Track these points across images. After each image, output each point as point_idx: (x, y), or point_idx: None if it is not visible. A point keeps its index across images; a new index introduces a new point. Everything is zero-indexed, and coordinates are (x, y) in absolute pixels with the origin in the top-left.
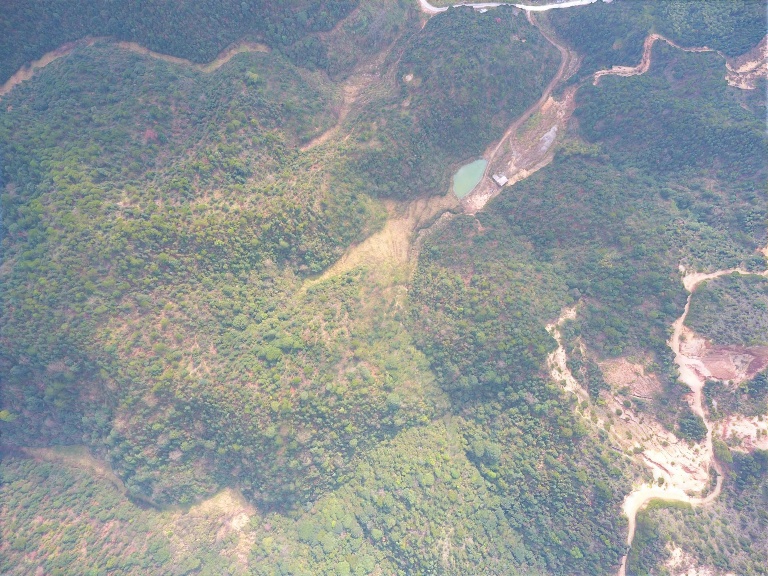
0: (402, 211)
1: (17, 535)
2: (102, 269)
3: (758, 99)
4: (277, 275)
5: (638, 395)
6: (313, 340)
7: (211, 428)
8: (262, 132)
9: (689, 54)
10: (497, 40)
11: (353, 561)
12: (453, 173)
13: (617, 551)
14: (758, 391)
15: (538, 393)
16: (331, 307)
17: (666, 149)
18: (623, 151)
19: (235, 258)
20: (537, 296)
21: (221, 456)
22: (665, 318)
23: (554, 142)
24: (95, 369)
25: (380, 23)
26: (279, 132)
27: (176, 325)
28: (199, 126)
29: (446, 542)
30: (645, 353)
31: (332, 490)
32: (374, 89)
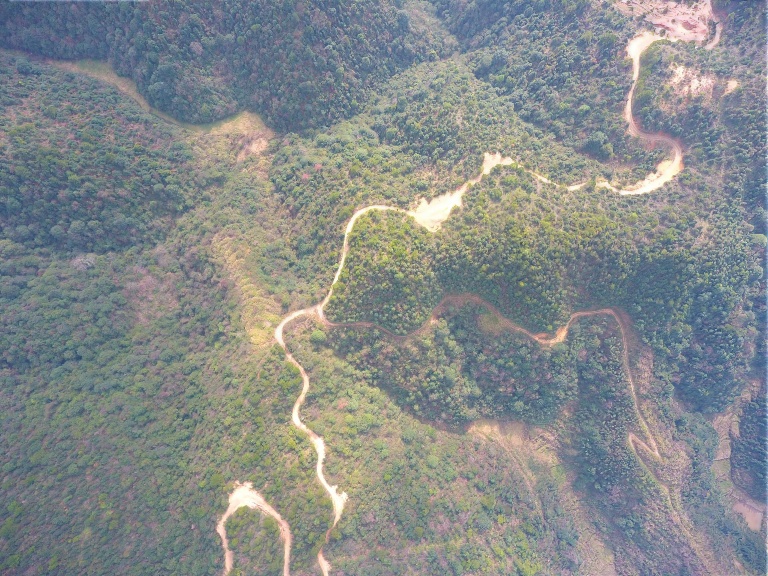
0: None
1: None
2: None
3: None
4: None
5: None
6: None
7: (230, 14)
8: None
9: None
10: None
11: (370, 147)
12: None
13: (623, 87)
14: None
15: None
16: None
17: None
18: None
19: None
20: None
21: (240, 56)
22: None
23: None
24: None
25: None
26: None
27: None
28: None
29: (459, 114)
30: None
31: (347, 119)
32: None
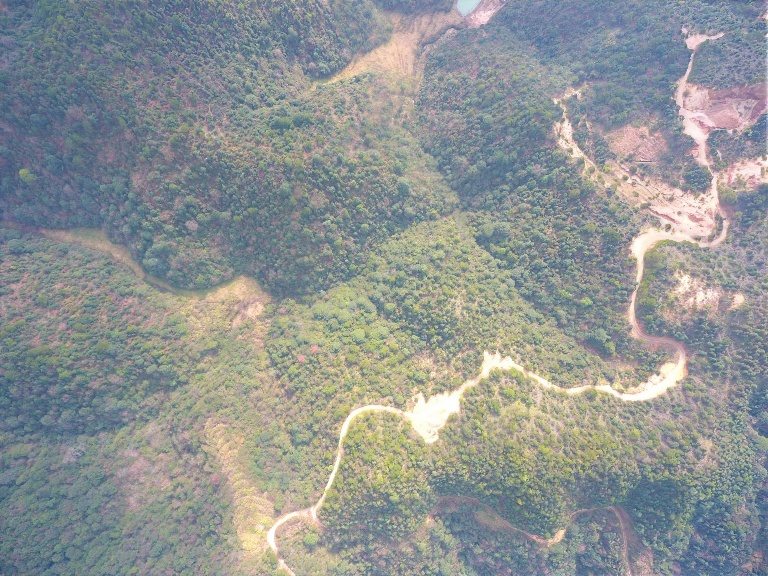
0: (407, 24)
1: (39, 295)
2: (118, 18)
3: None
4: (287, 69)
5: (644, 160)
6: None
7: (226, 195)
8: None
9: None
10: None
11: (368, 328)
12: None
13: (626, 289)
14: (761, 134)
15: (545, 164)
16: (340, 98)
17: None
18: None
19: (246, 38)
20: (542, 79)
21: (236, 231)
22: (669, 78)
23: None
24: (112, 124)
25: None
26: None
27: (190, 89)
28: None
29: (458, 300)
30: (650, 115)
31: (345, 281)
32: None
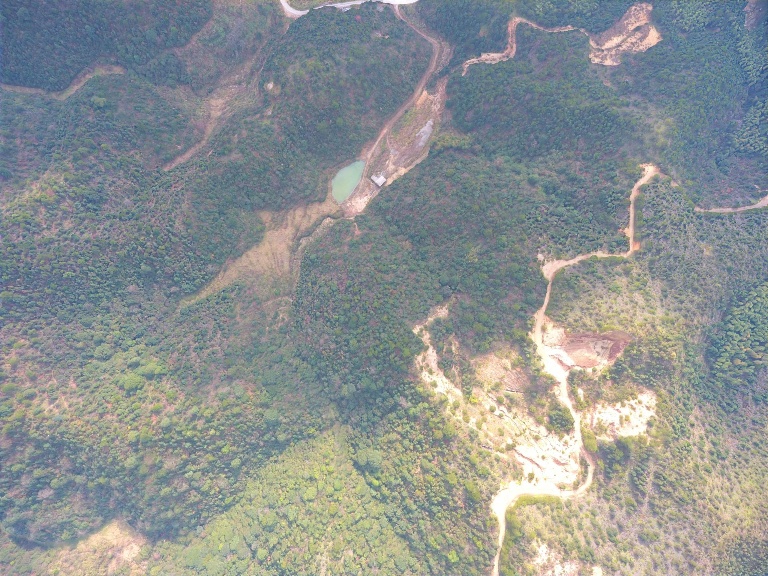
0: (279, 221)
1: None
2: None
3: (622, 75)
4: (145, 300)
5: (510, 390)
6: (177, 364)
7: (77, 463)
8: (116, 156)
9: (551, 35)
10: (356, 39)
11: None
12: (330, 178)
13: (488, 552)
14: (620, 376)
15: (411, 397)
16: (202, 327)
17: (532, 135)
18: (494, 140)
19: (91, 288)
20: (407, 297)
21: (95, 489)
22: (527, 309)
23: (431, 137)
24: None
25: (239, 33)
26: (136, 154)
27: (28, 363)
28: (46, 157)
29: (324, 557)
30: (511, 347)
31: (223, 512)
32: (239, 100)
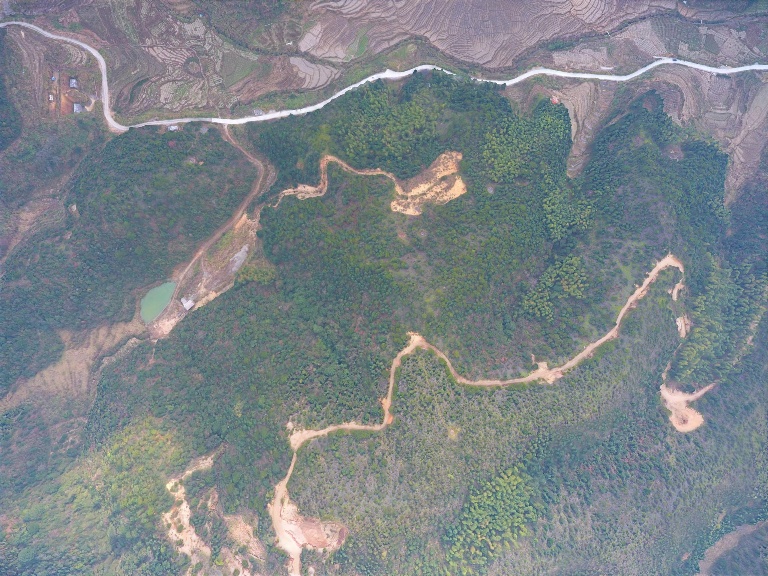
0: (80, 341)
1: None
2: None
3: (419, 227)
4: None
5: (256, 555)
6: None
7: None
8: None
9: (357, 178)
10: (162, 168)
11: None
12: (139, 298)
13: None
14: None
15: (158, 552)
16: None
17: (323, 281)
18: (295, 278)
19: None
20: (174, 444)
21: None
22: (271, 479)
23: (245, 262)
24: None
25: (52, 149)
26: None
27: None
28: None
29: None
30: (254, 514)
31: None
32: (48, 217)
